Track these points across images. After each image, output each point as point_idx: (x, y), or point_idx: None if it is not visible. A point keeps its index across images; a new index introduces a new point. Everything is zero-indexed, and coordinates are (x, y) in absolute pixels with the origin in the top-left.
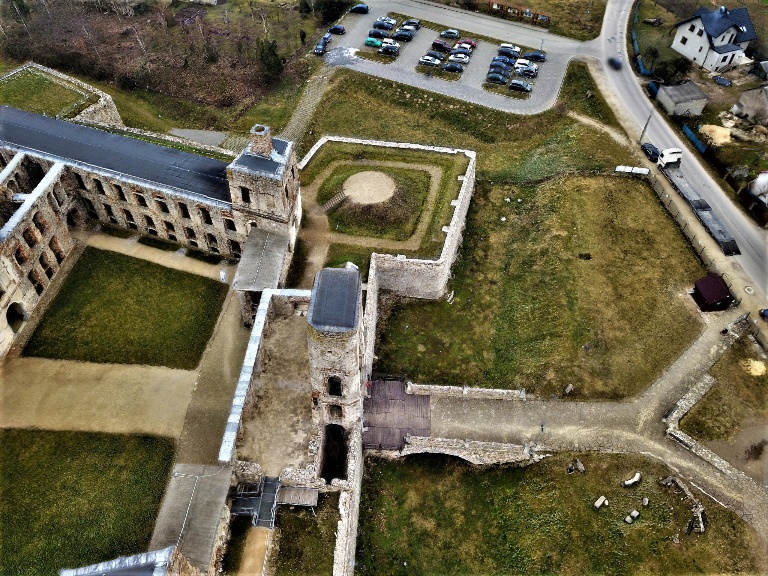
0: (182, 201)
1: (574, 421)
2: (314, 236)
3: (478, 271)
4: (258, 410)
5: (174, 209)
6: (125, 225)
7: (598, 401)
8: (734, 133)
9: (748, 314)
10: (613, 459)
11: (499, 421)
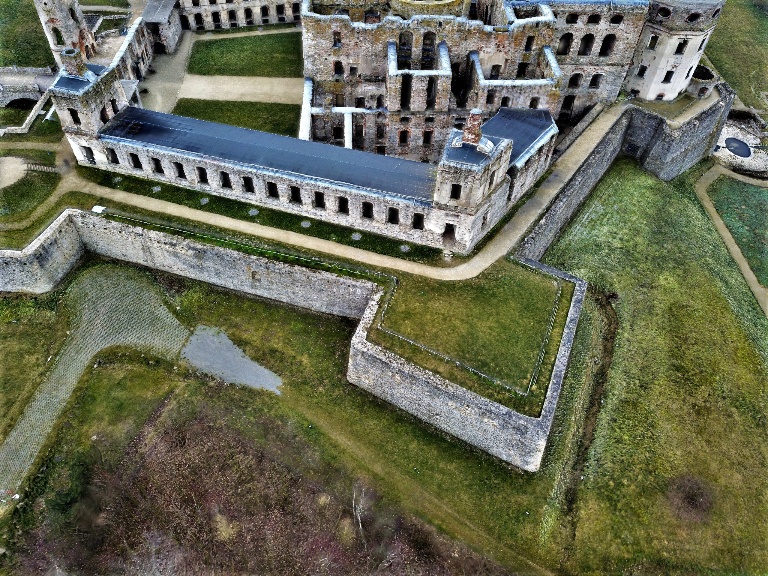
0: None
1: None
2: None
3: None
4: None
5: None
6: None
7: None
8: None
9: None
10: None
11: None
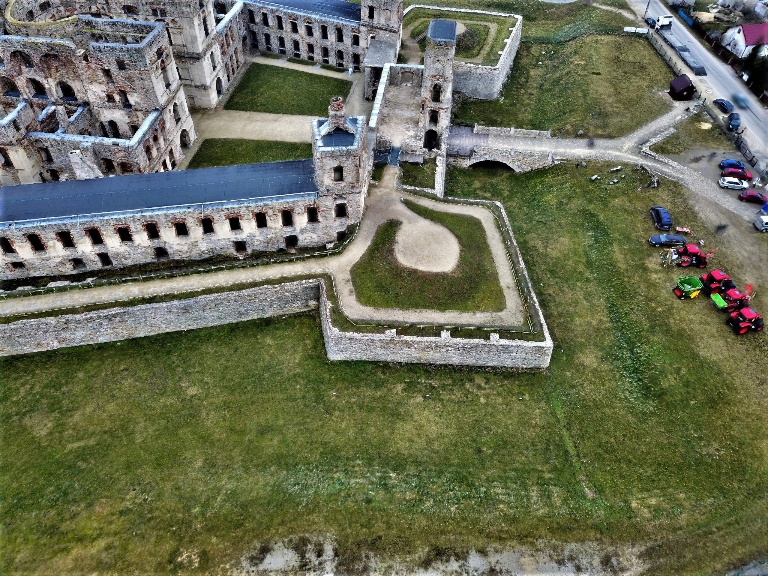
0: (324, 24)
1: (582, 147)
2: (410, 53)
3: (521, 88)
4: (384, 121)
5: (317, 31)
6: (277, 51)
7: (598, 139)
8: (717, 16)
9: (704, 100)
10: (605, 163)
11: (533, 146)
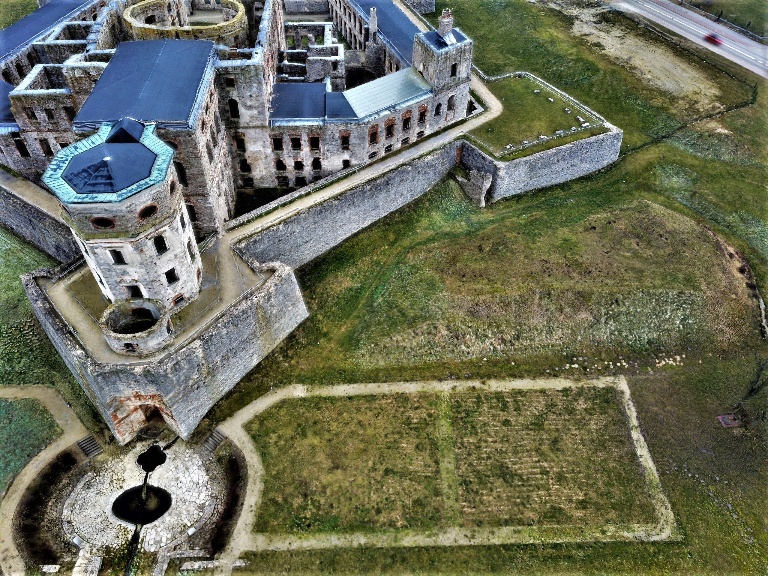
0: None
1: None
2: None
3: None
4: None
5: None
6: None
7: None
8: None
9: None
10: None
11: None
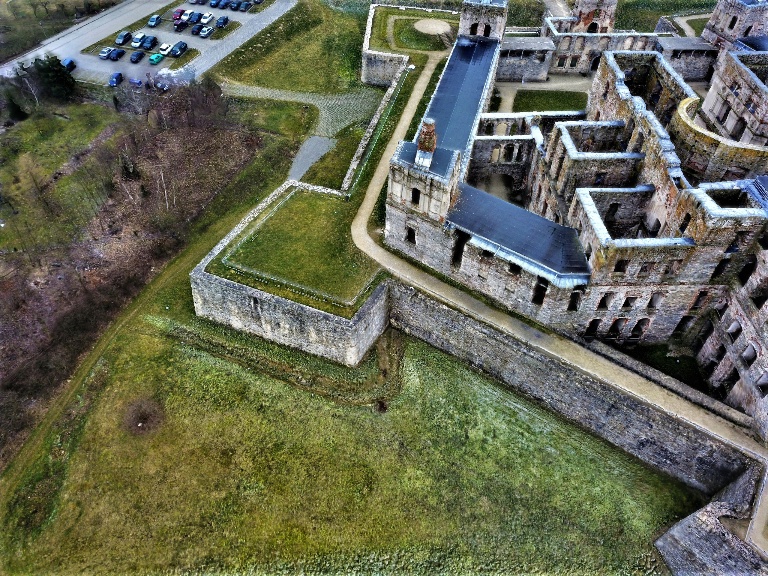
0: None
1: (555, 3)
2: None
3: None
4: None
5: None
6: None
7: None
8: None
9: None
10: None
11: None
